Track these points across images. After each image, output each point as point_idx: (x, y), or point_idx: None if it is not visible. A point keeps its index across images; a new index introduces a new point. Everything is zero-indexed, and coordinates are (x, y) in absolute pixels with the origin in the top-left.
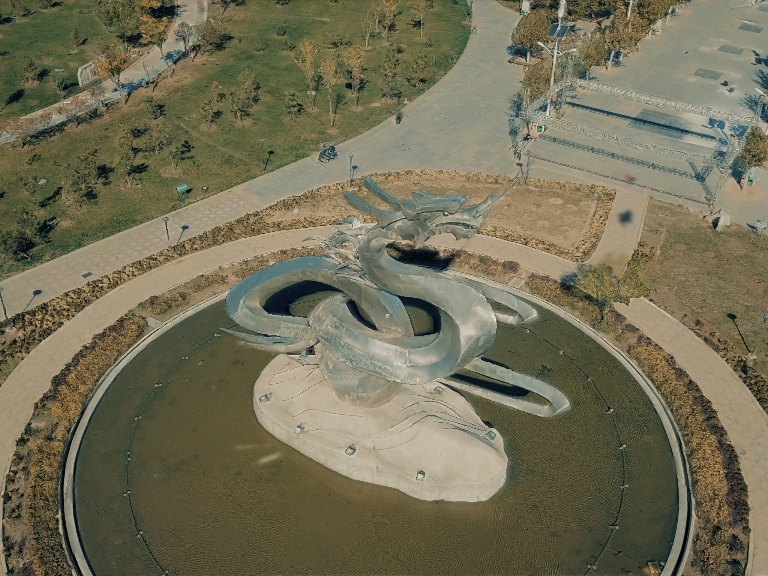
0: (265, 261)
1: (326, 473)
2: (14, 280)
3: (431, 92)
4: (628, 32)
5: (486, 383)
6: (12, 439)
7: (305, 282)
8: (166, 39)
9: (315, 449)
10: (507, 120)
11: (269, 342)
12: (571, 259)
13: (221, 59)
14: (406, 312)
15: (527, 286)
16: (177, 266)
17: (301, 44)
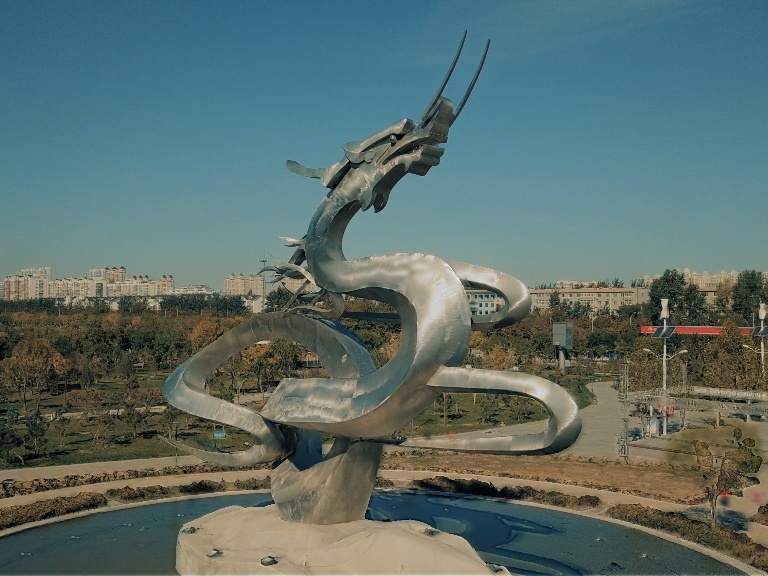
0: None
1: None
2: None
3: (533, 423)
4: (762, 377)
5: (520, 570)
6: None
7: None
8: None
9: (226, 574)
10: (617, 437)
11: None
12: (675, 502)
13: None
14: None
15: (607, 513)
16: (176, 478)
17: (389, 352)
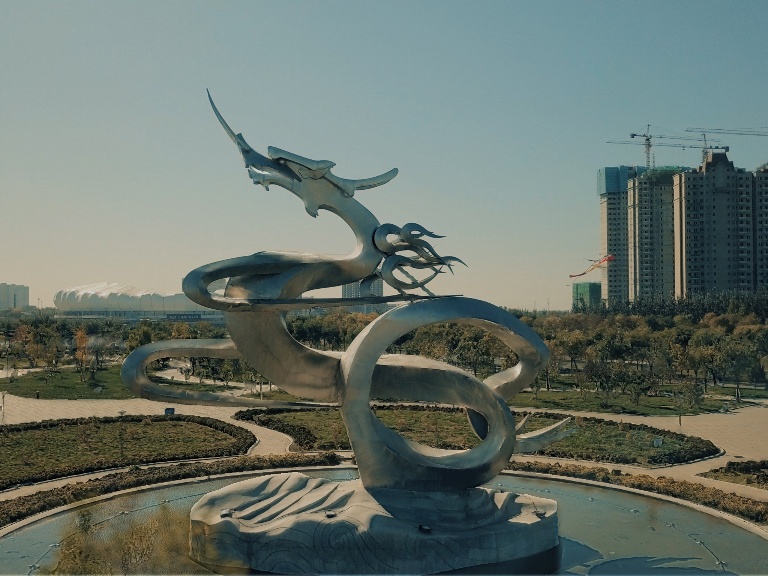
0: None
1: None
2: None
3: None
4: None
5: None
6: None
7: None
8: None
9: None
10: None
11: None
12: None
13: None
14: (357, 349)
15: None
16: None
17: None
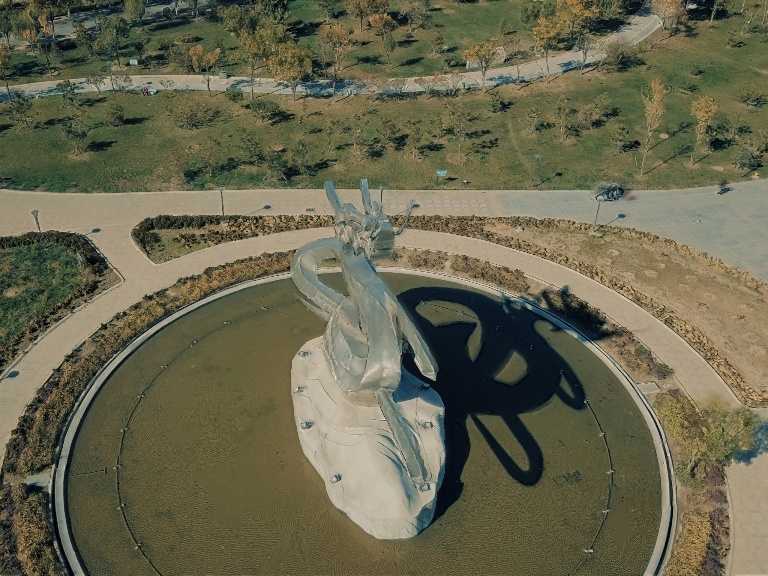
0: (444, 258)
1: None
2: (264, 192)
3: None
4: None
5: (503, 453)
6: (147, 293)
7: (456, 290)
8: None
9: (295, 411)
10: None
11: None
12: (741, 398)
13: (611, 80)
14: None
15: (656, 396)
16: None
17: (654, 81)
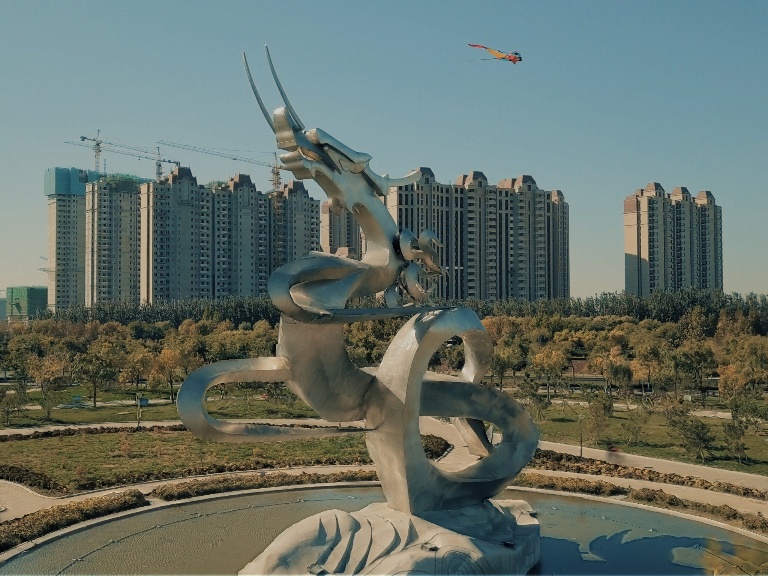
0: None
1: None
2: (666, 462)
3: None
4: None
5: None
6: None
7: None
8: None
9: None
10: None
11: None
12: None
13: None
14: (410, 364)
15: None
16: (748, 502)
17: None
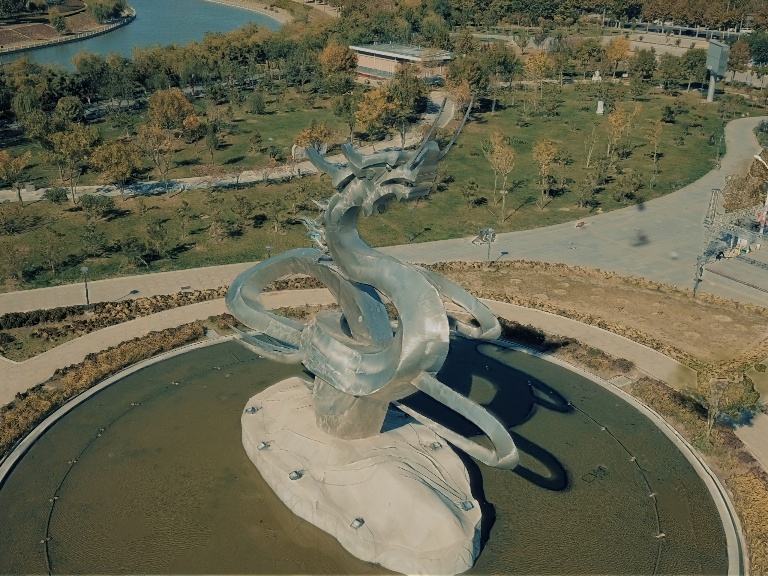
0: None
1: (277, 503)
2: (124, 280)
3: (634, 208)
4: None
5: None
6: None
7: None
8: (394, 139)
9: (269, 469)
10: (709, 241)
11: (270, 349)
12: None
13: None
14: (389, 324)
15: (631, 387)
16: (269, 297)
17: (492, 135)
